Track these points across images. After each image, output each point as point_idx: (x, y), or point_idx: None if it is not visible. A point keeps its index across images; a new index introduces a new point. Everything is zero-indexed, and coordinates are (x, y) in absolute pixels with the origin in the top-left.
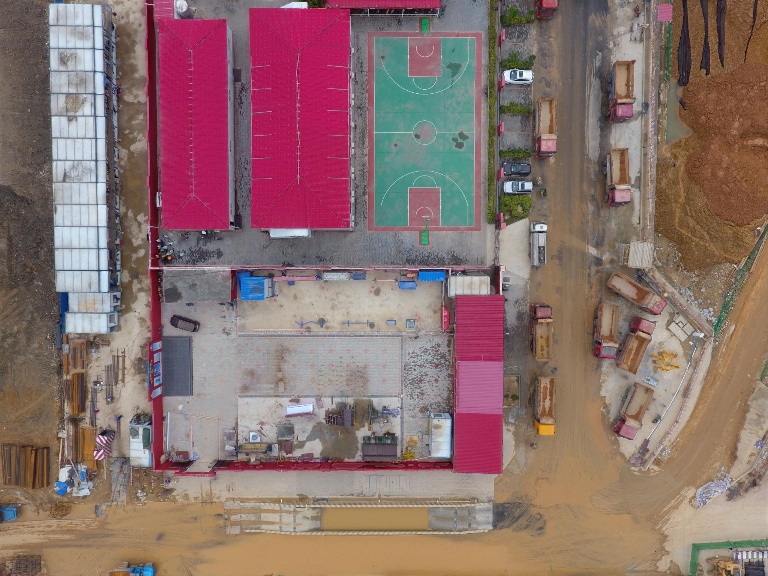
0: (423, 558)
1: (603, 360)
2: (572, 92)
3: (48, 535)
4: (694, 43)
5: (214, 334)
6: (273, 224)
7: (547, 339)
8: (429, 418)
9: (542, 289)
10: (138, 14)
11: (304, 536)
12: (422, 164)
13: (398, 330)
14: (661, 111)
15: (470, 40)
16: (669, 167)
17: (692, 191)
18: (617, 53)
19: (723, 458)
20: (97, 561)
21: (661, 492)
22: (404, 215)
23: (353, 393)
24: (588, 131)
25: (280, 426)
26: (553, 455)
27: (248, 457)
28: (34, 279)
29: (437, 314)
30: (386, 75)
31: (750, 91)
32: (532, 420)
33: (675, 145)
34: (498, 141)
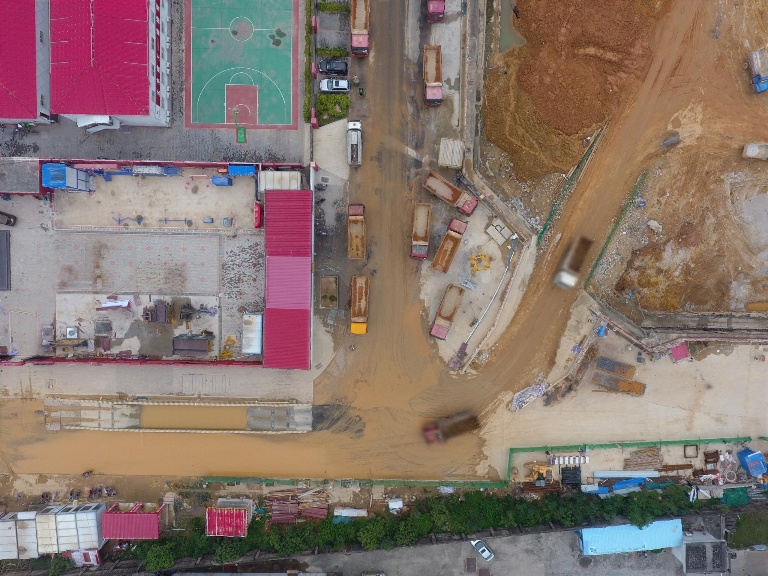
0: (243, 458)
1: (422, 263)
2: None
3: None
4: None
5: (32, 229)
6: (72, 109)
7: (362, 239)
8: None
9: (361, 191)
10: None
11: (122, 433)
12: (239, 61)
13: (216, 228)
14: (494, 19)
15: None
16: (500, 75)
17: (521, 99)
18: None
19: (542, 364)
20: None
21: (478, 396)
22: (221, 112)
23: (171, 291)
24: (408, 31)
25: (97, 322)
26: (372, 358)
27: (66, 353)
28: None
29: None
30: None
31: None
32: None
33: (508, 54)
34: (314, 38)
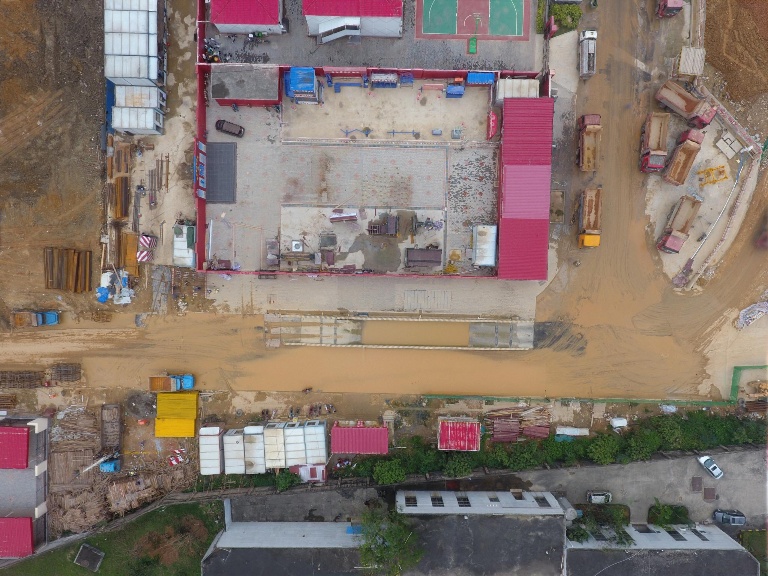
0: (463, 376)
1: (649, 178)
2: None
3: (88, 344)
4: None
5: (258, 141)
6: (325, 11)
7: (594, 151)
8: (472, 232)
9: (589, 104)
10: None
11: (344, 349)
12: None
13: (443, 141)
14: None
15: None
16: None
17: (741, 15)
18: None
19: (767, 281)
20: (136, 371)
21: (704, 313)
22: (452, 23)
23: (397, 205)
24: None
25: (323, 236)
26: (596, 274)
27: (290, 267)
28: (79, 80)
29: (483, 126)
30: None
31: None
32: (576, 237)
33: None
34: None
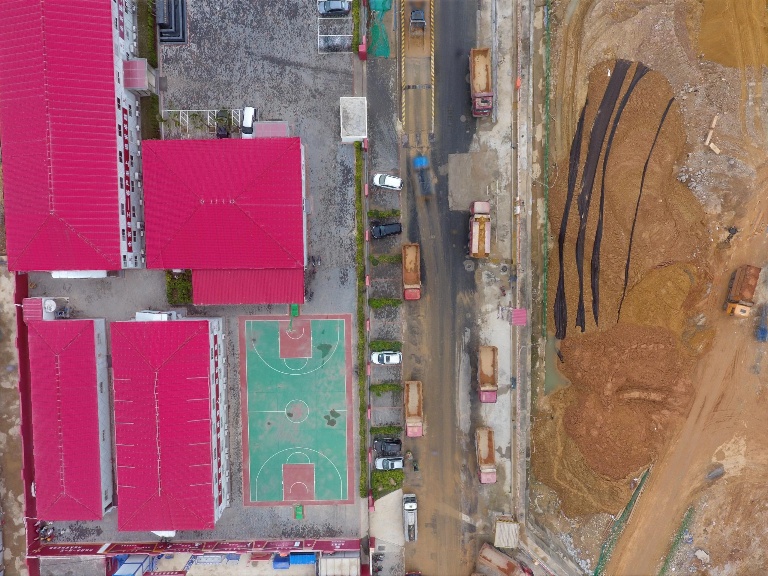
0: None
1: None
2: (442, 368)
3: None
4: (569, 300)
5: None
6: (139, 528)
7: None
8: None
9: (417, 555)
10: (12, 304)
11: None
12: (295, 441)
13: None
14: (539, 364)
15: (339, 322)
16: (547, 420)
17: (569, 446)
18: (485, 329)
19: None
20: None
21: None
22: (279, 490)
23: None
24: (459, 404)
25: None
26: None
27: None
28: None
29: None
30: (257, 357)
31: (621, 355)
32: None
33: (554, 396)
34: (369, 419)
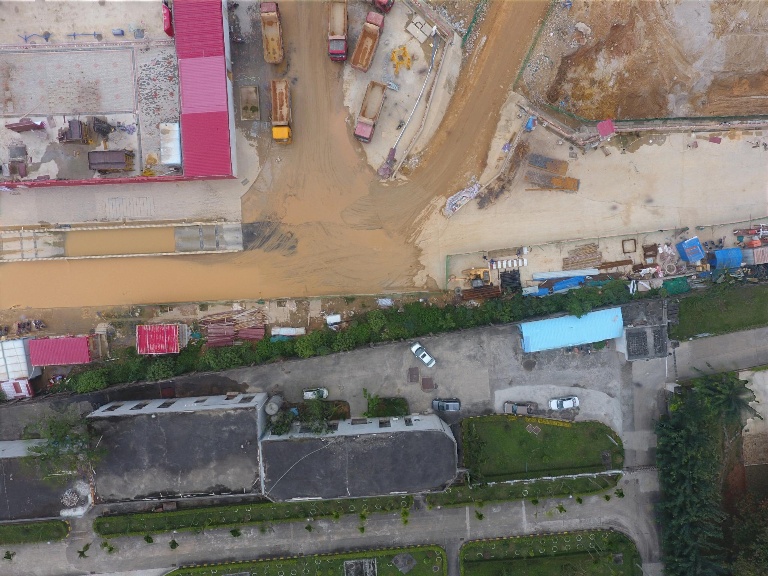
0: (175, 284)
1: (344, 68)
2: None
3: None
4: None
5: None
6: None
7: (278, 41)
8: None
9: None
10: None
11: (47, 262)
12: None
13: (127, 41)
14: None
15: None
16: None
17: None
18: None
19: (474, 167)
20: None
21: (410, 202)
22: None
23: (86, 110)
24: None
25: (11, 147)
26: (300, 170)
27: None
28: None
29: None
30: None
31: None
32: None
33: None
34: None
